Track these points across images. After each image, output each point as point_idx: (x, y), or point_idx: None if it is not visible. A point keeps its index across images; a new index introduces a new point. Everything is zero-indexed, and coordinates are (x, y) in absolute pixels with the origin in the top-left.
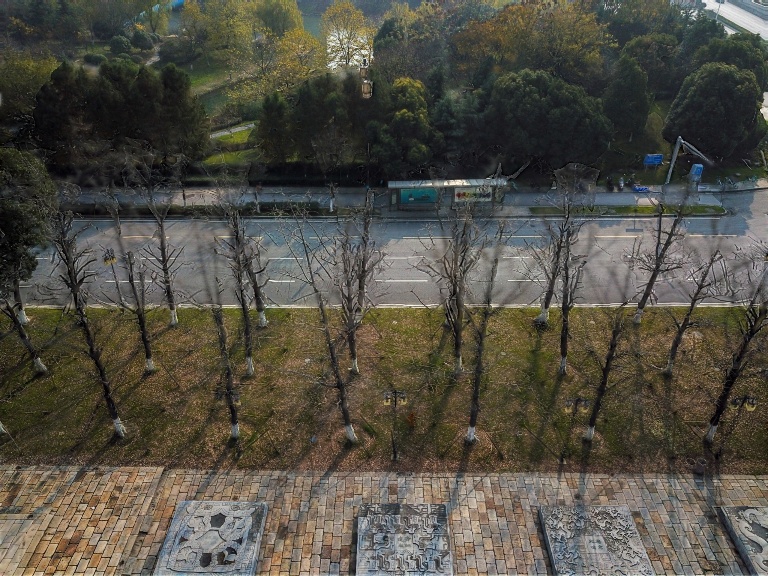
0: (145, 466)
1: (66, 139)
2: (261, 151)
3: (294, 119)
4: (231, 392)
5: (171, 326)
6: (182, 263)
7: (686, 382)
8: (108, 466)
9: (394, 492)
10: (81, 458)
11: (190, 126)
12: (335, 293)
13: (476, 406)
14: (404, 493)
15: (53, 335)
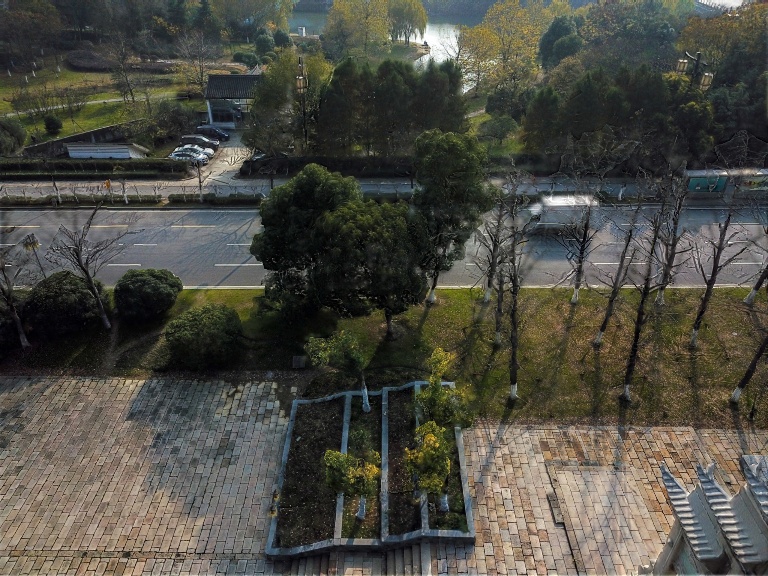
0: (675, 426)
1: (346, 132)
2: (523, 143)
3: (572, 112)
4: None
5: (573, 304)
6: (600, 244)
7: None
8: (640, 426)
9: None
10: (609, 419)
11: (460, 119)
12: (696, 274)
13: None
14: None
15: (473, 312)
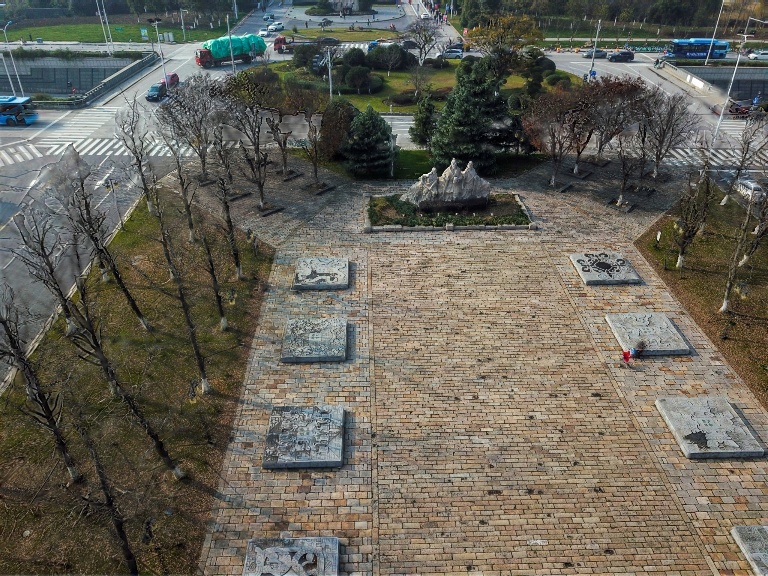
0: None
1: None
2: None
3: None
4: (148, 522)
5: None
6: None
7: (187, 273)
8: None
9: (250, 444)
10: None
11: None
12: None
13: (201, 358)
14: (253, 437)
15: None
